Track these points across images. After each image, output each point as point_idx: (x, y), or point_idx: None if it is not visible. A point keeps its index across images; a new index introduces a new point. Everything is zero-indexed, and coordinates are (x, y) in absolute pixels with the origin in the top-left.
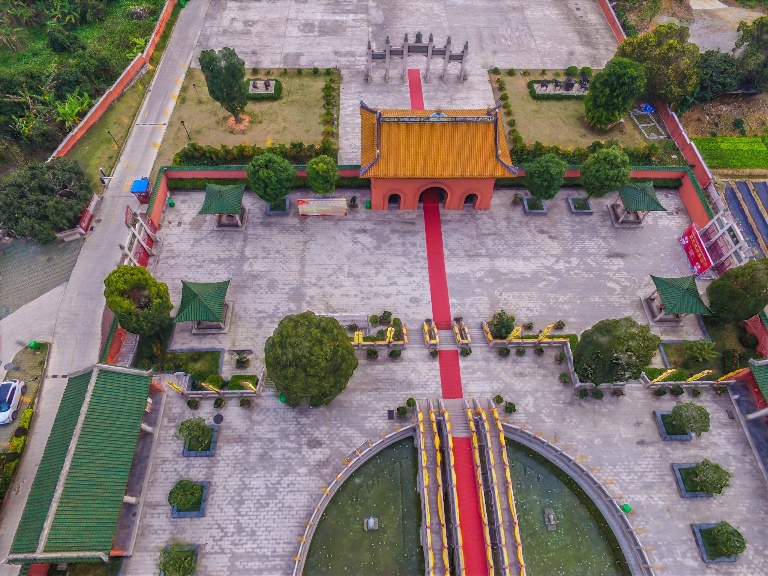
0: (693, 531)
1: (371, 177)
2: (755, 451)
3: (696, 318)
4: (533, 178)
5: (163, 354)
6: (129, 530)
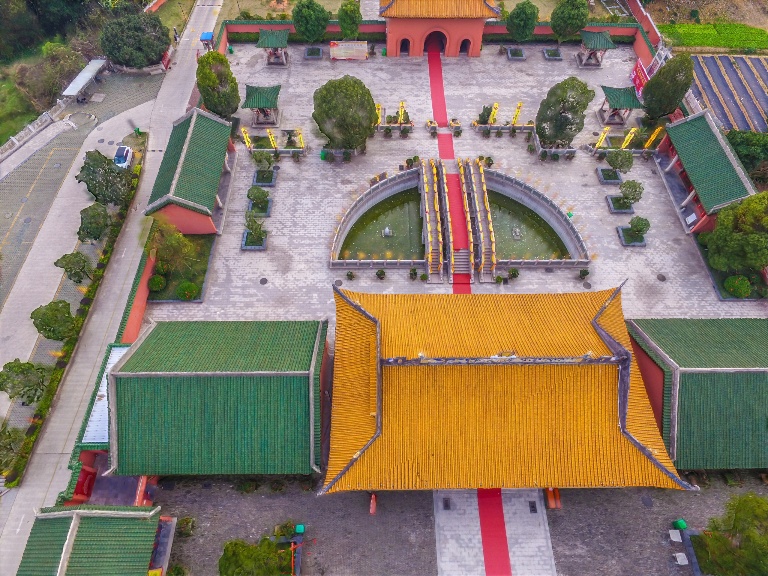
0: (617, 230)
1: (387, 16)
2: (669, 190)
3: (637, 123)
4: (513, 19)
5: (232, 137)
6: (219, 222)
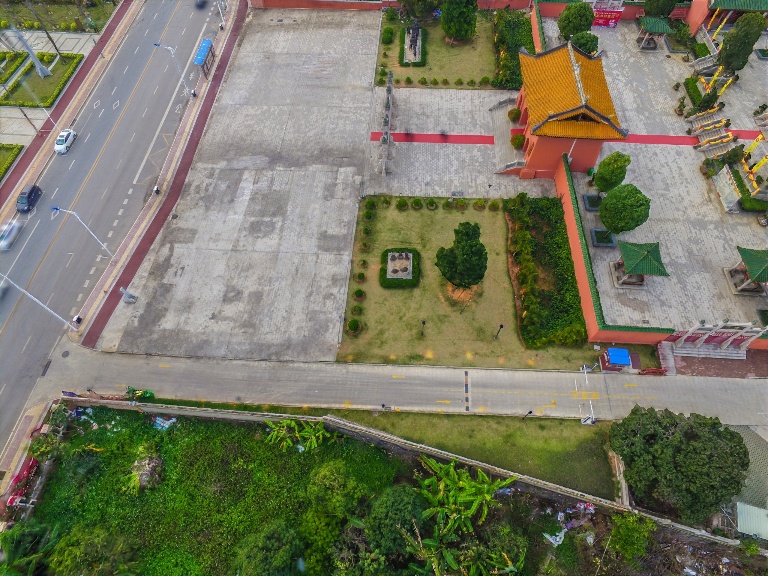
0: None
1: None
2: None
3: None
4: None
5: None
6: None
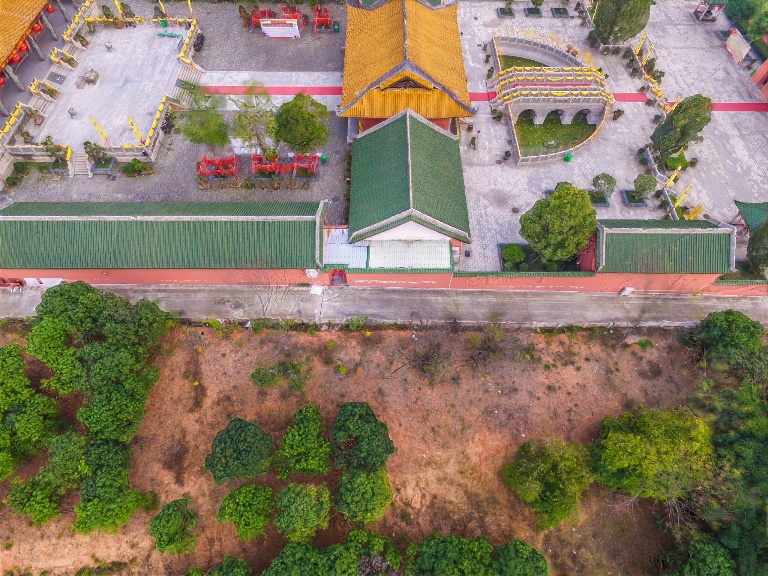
0: None
1: None
2: None
3: (745, 258)
4: None
5: None
6: None
